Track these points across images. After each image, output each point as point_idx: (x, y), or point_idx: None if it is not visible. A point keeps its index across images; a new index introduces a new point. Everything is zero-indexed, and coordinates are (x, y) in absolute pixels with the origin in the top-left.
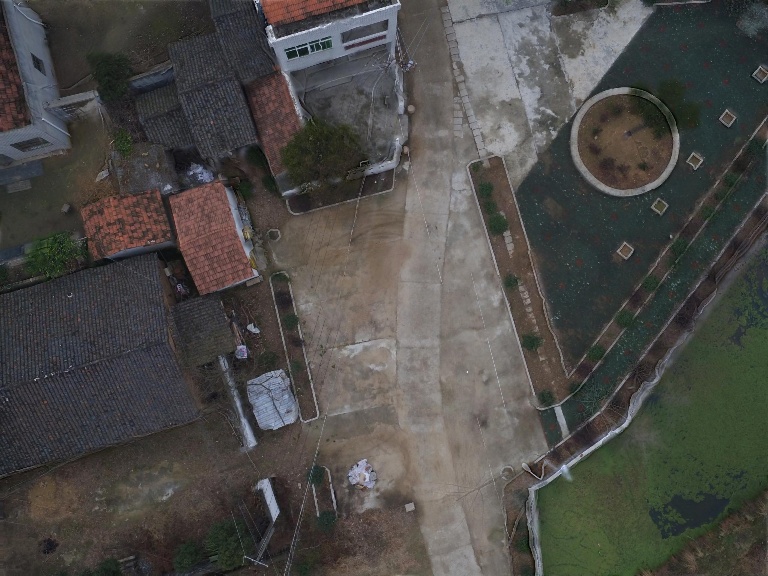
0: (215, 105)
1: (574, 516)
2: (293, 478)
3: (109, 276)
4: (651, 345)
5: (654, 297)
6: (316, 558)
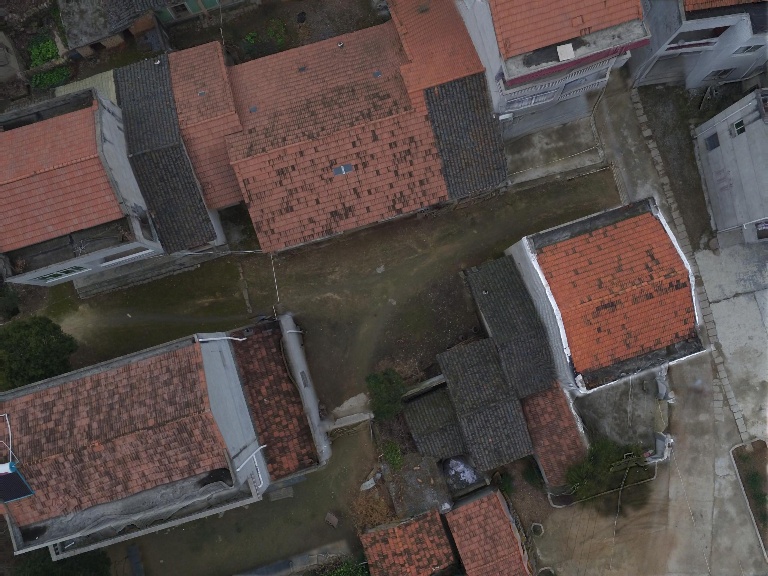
0: (494, 424)
1: None
2: None
3: None
4: None
5: None
6: None
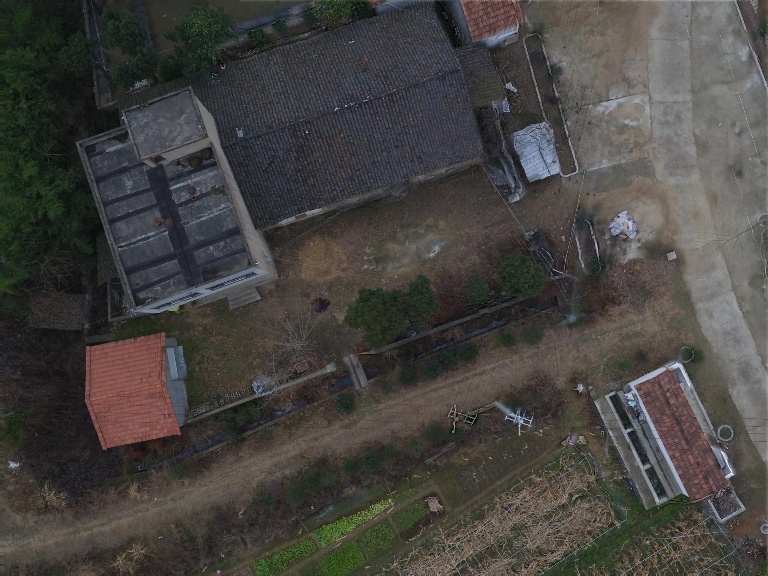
0: None
1: None
2: (556, 231)
3: (387, 23)
4: None
5: None
6: (583, 308)
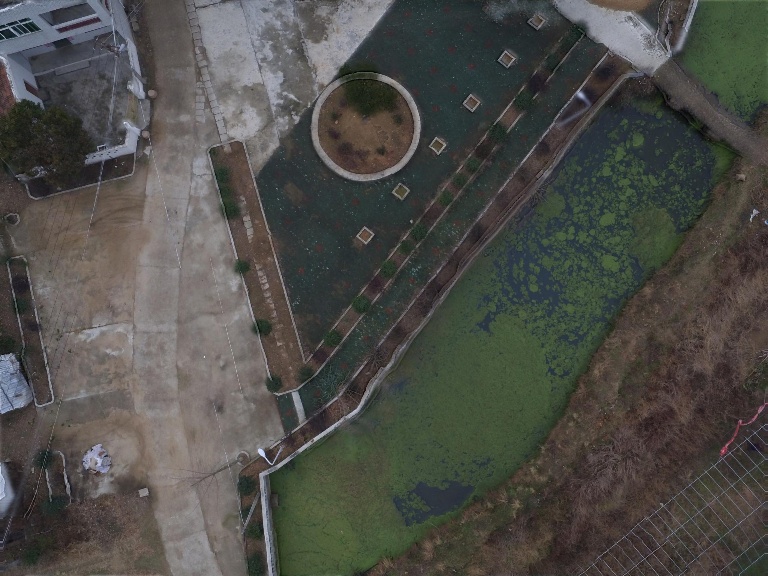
0: None
1: (317, 503)
2: (27, 463)
3: None
4: (390, 330)
5: (394, 282)
6: (48, 543)
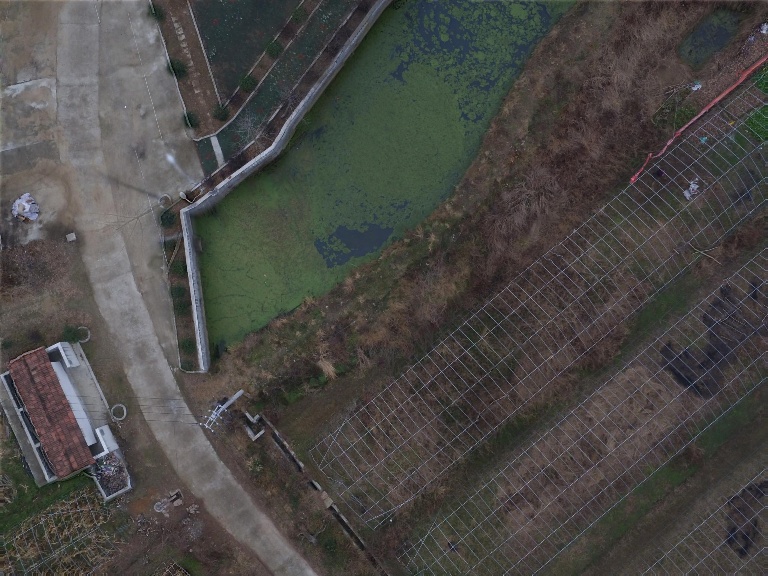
0: None
1: (240, 249)
2: None
3: None
4: (303, 75)
5: (306, 29)
6: None
